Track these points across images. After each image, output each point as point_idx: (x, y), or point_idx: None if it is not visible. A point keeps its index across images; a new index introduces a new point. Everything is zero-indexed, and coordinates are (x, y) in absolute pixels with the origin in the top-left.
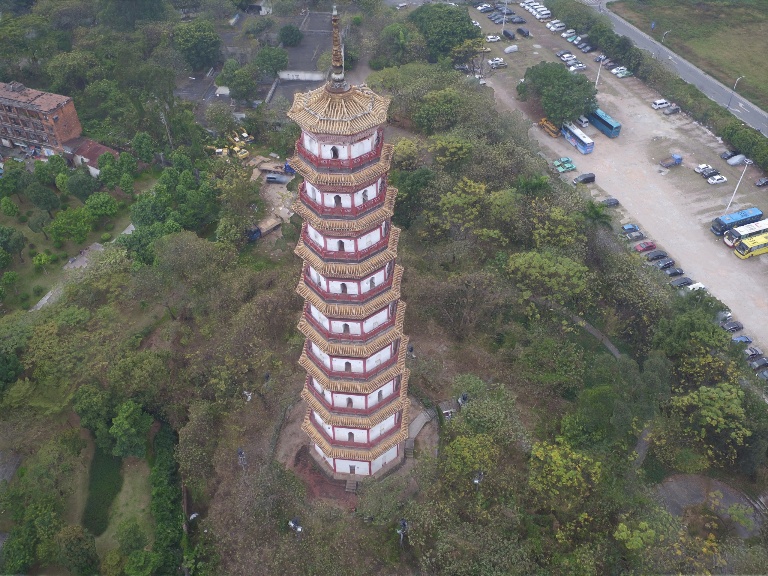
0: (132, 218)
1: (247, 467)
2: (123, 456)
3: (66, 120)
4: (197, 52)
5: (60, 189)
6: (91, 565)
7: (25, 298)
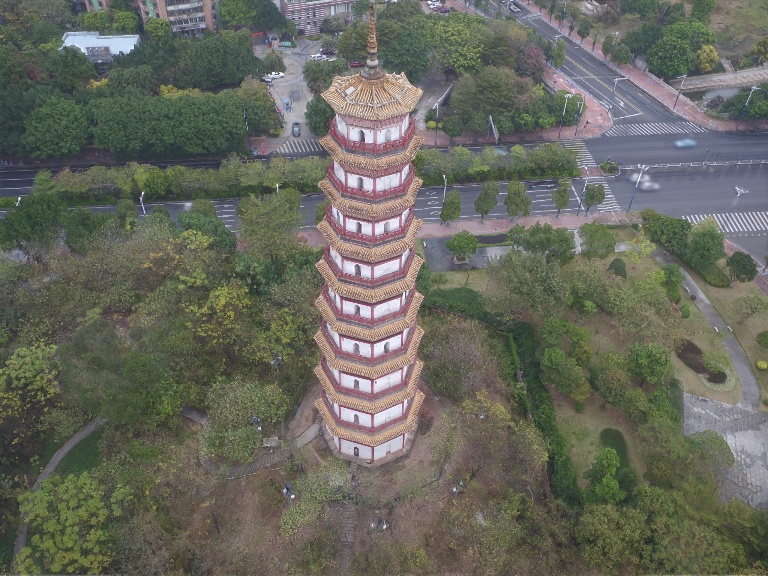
0: None
1: None
2: None
3: None
4: None
5: None
6: None
7: None
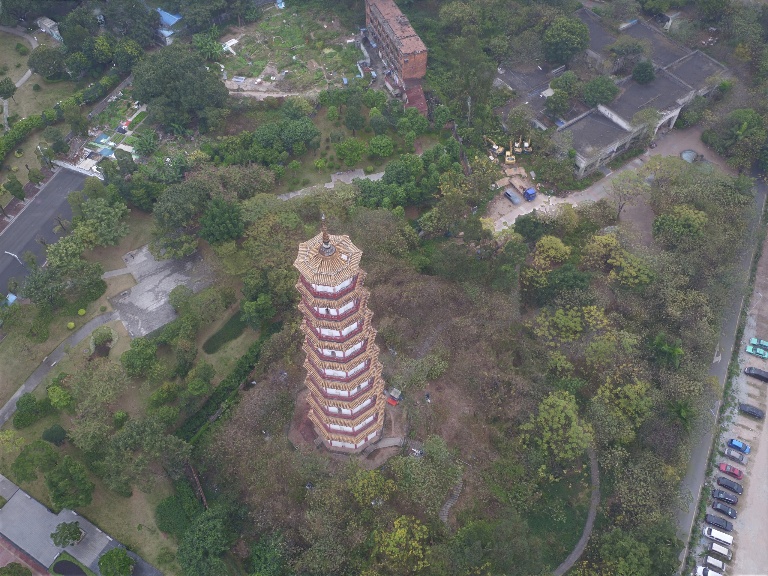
0: (386, 170)
1: (288, 382)
2: (247, 323)
3: (415, 64)
4: (556, 49)
5: (370, 117)
6: (186, 367)
7: (295, 183)
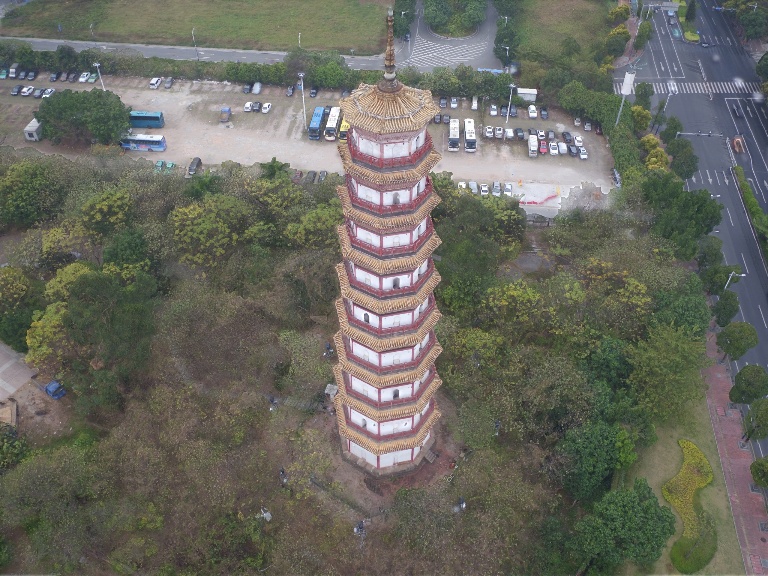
0: None
1: None
2: None
3: None
4: None
5: None
6: None
7: None
